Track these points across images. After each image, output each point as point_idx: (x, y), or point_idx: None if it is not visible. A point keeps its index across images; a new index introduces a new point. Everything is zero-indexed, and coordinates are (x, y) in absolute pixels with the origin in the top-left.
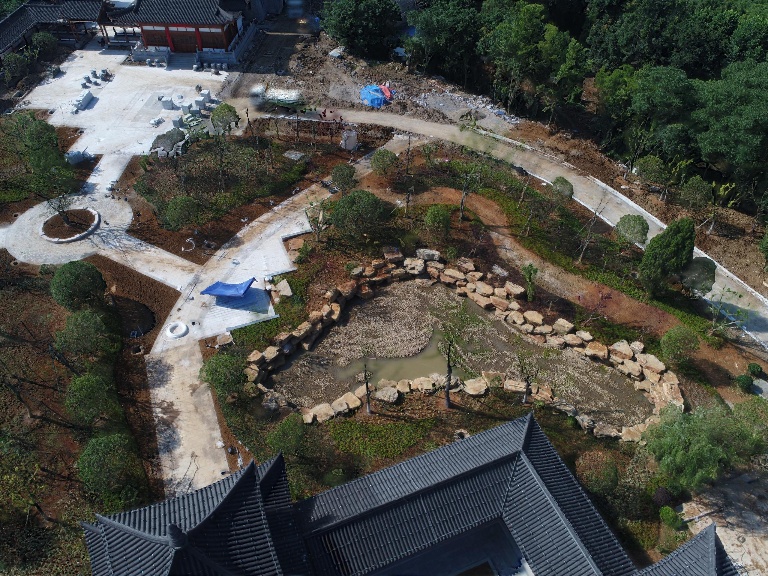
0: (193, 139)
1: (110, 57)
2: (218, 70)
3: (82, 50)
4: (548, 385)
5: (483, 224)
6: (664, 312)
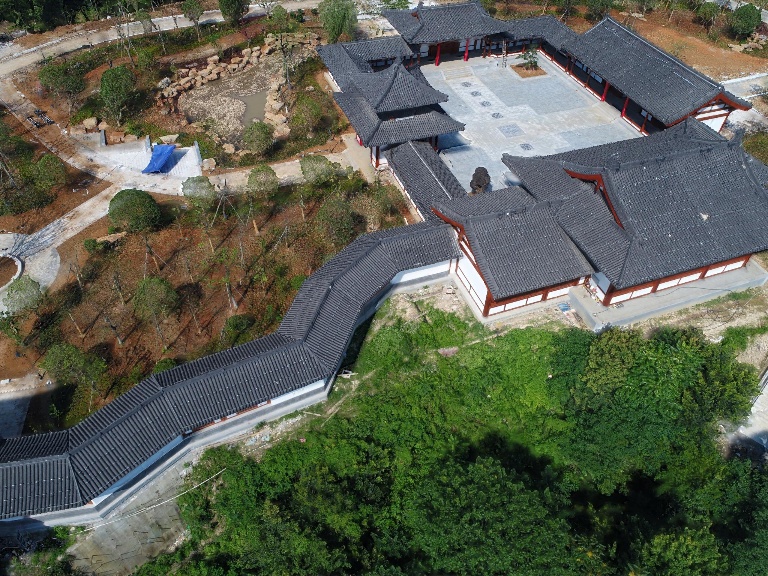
0: None
1: None
2: None
3: None
4: None
5: None
6: (248, 27)
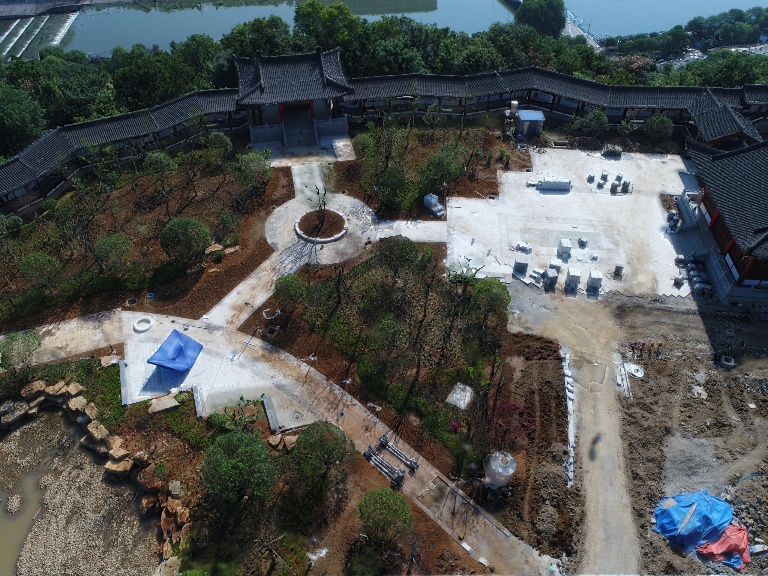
0: (461, 279)
1: (675, 182)
2: (690, 283)
3: (682, 159)
4: None
5: None
6: None
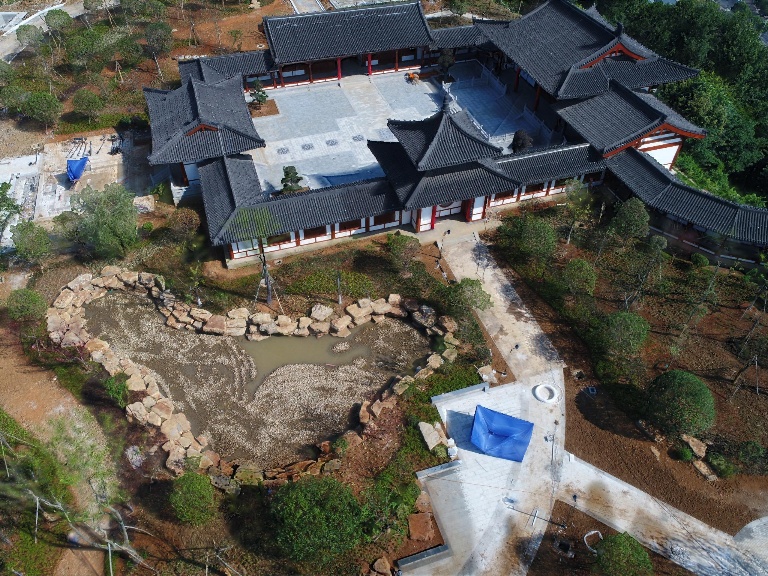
0: None
1: None
2: None
3: None
4: (166, 328)
5: (107, 551)
6: None
